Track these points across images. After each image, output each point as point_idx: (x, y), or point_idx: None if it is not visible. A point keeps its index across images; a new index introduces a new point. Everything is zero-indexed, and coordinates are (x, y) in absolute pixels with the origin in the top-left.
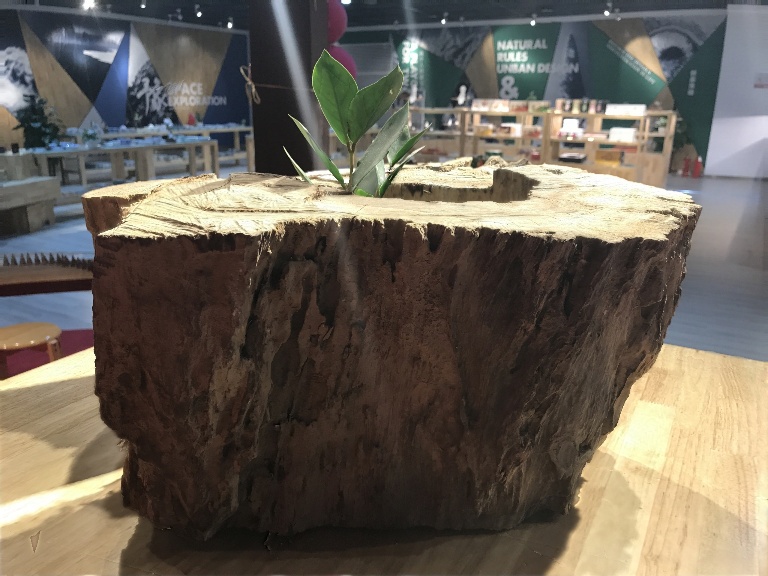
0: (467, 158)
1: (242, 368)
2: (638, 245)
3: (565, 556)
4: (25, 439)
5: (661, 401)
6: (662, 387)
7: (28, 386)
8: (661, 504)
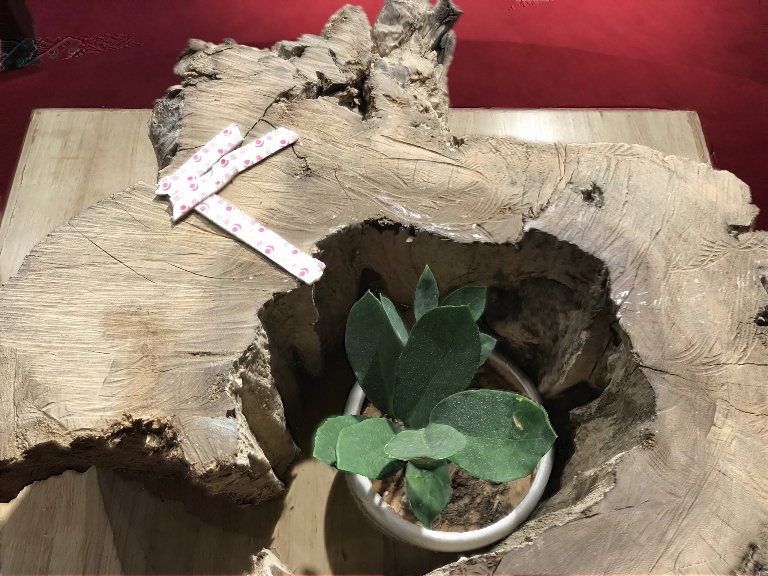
0: (360, 20)
1: None
2: None
3: None
4: None
5: None
6: None
7: None
8: None
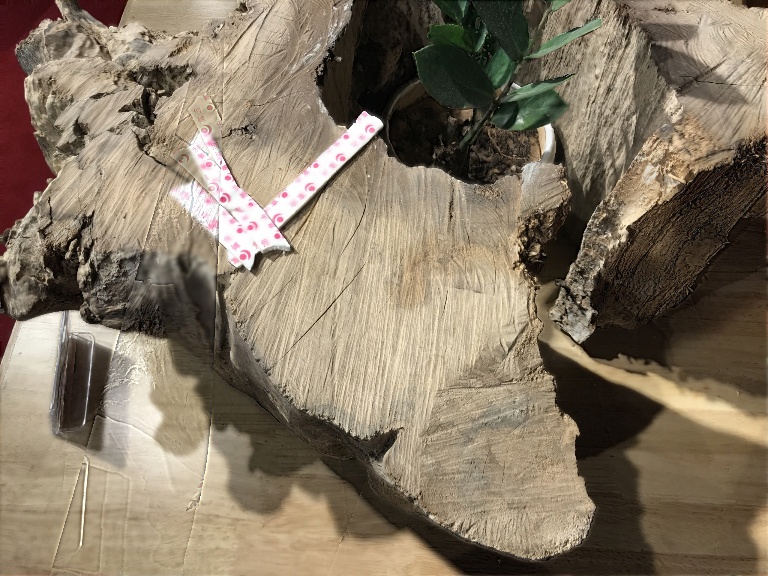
0: (60, 64)
1: None
2: None
3: None
4: (650, 519)
5: None
6: None
7: None
8: None
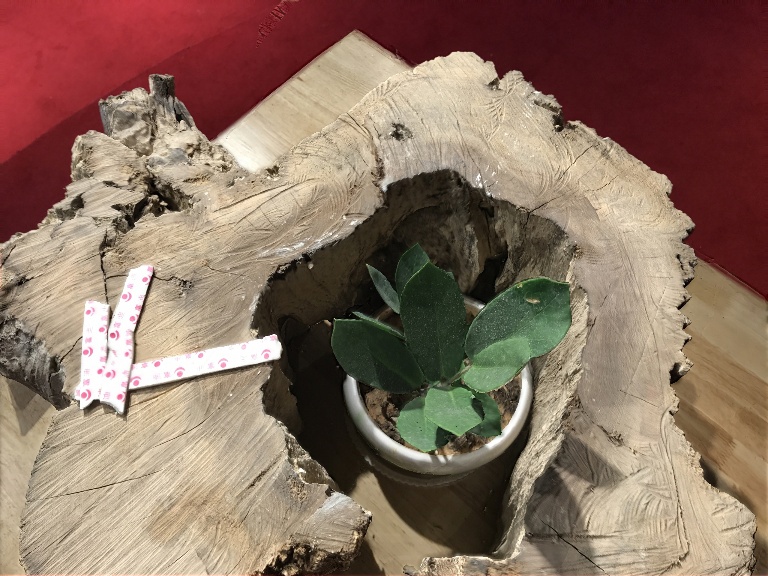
0: (105, 140)
1: None
2: None
3: None
4: None
5: None
6: None
7: None
8: None
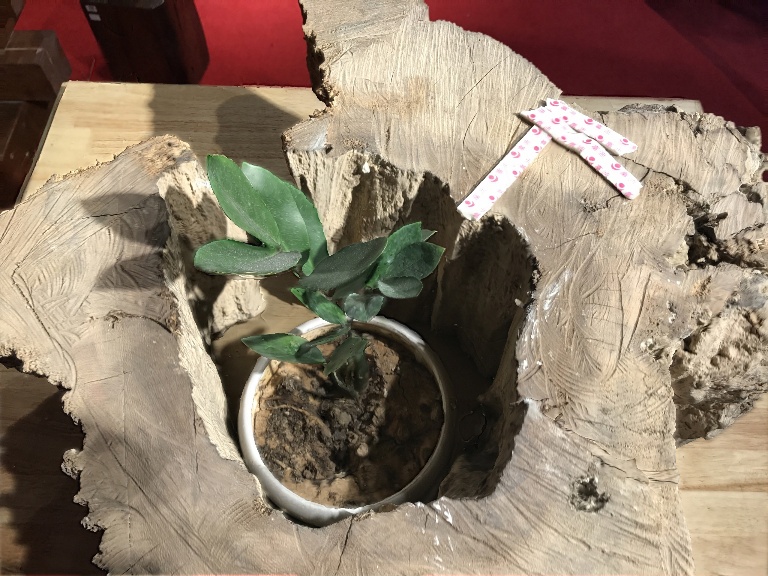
0: None
1: None
2: None
3: None
4: None
5: None
6: None
7: (286, 110)
8: None
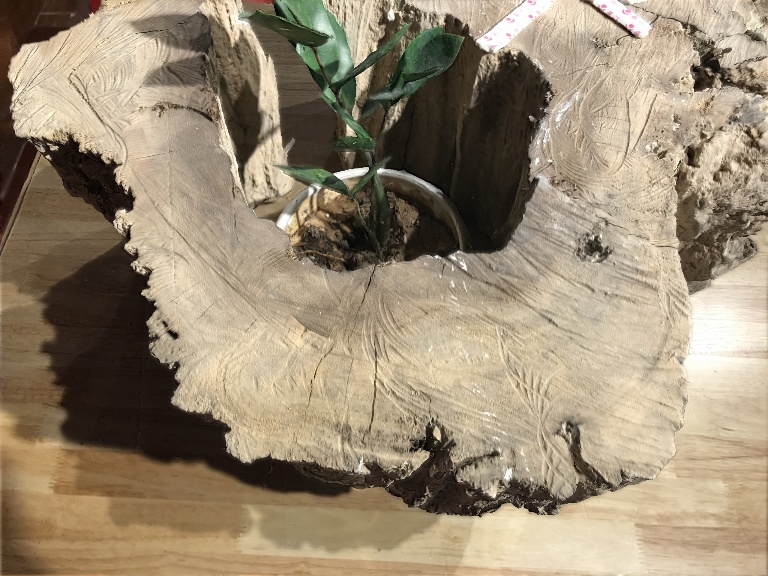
0: None
1: (91, 197)
2: (226, 430)
3: (274, 493)
4: None
5: (651, 552)
6: (700, 550)
7: None
8: (396, 570)
